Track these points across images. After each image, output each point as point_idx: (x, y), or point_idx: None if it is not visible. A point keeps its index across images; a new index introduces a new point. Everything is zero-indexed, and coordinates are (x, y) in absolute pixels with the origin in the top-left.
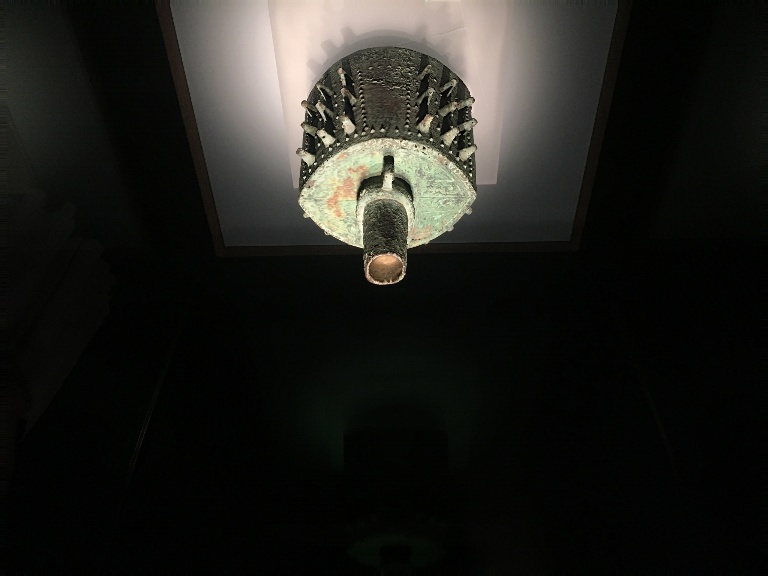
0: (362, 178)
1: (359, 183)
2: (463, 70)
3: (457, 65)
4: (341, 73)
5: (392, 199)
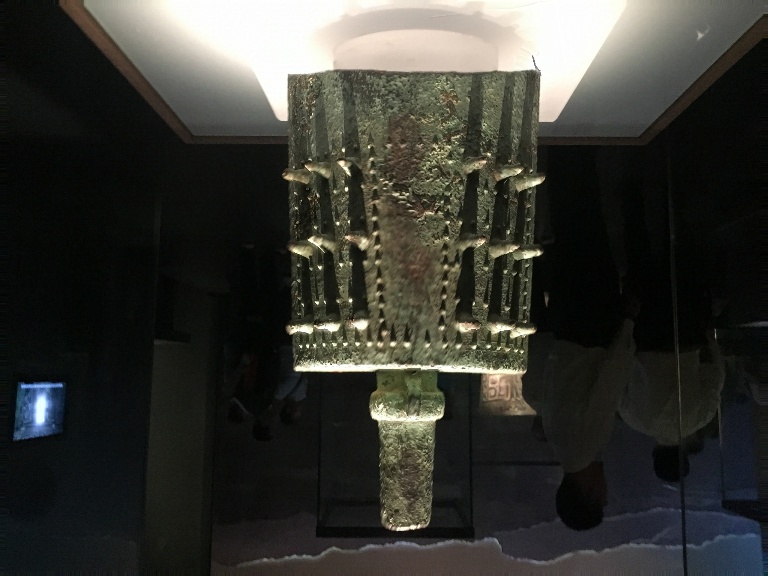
0: None
1: None
2: (536, 39)
3: (528, 35)
4: (343, 166)
5: (417, 421)
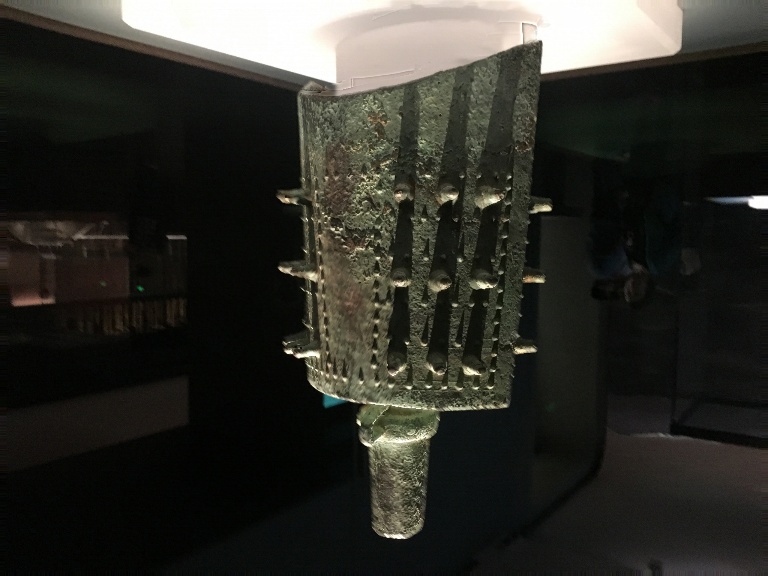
0: None
1: None
2: (516, 7)
3: (500, 5)
4: None
5: (389, 442)
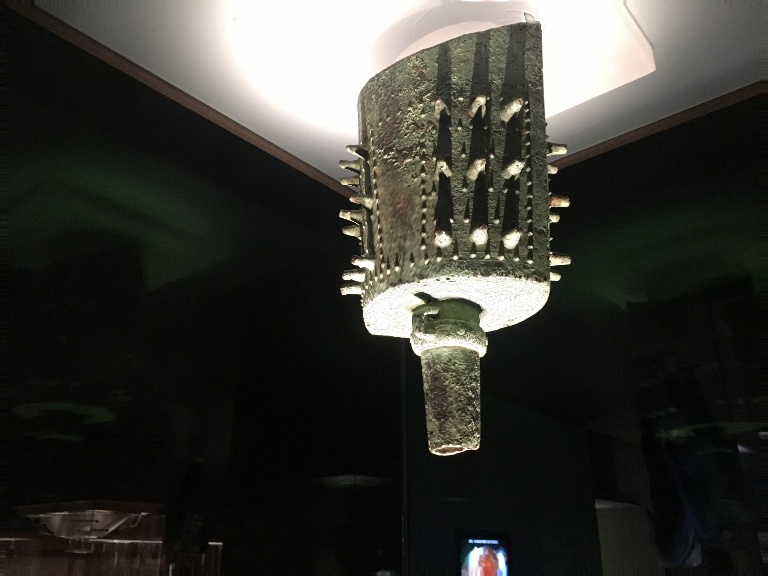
0: (409, 309)
1: (410, 312)
2: None
3: None
4: None
5: (440, 346)
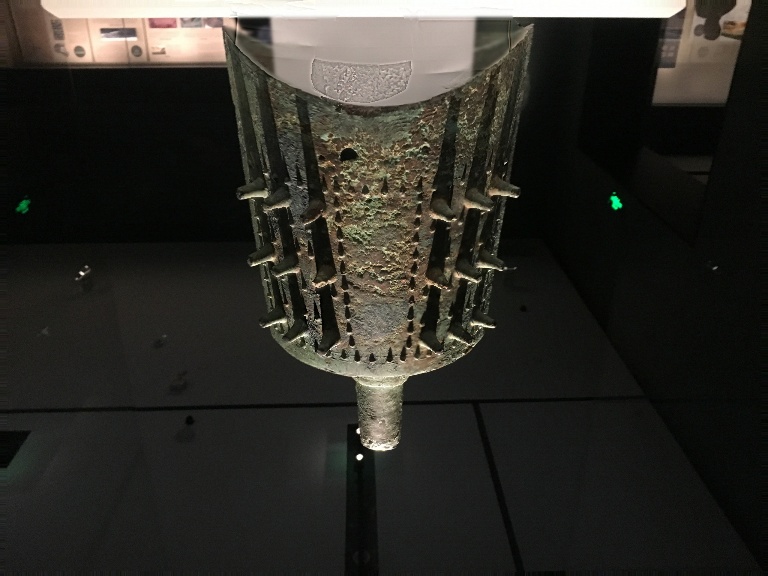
0: None
1: None
2: None
3: None
4: None
5: None
